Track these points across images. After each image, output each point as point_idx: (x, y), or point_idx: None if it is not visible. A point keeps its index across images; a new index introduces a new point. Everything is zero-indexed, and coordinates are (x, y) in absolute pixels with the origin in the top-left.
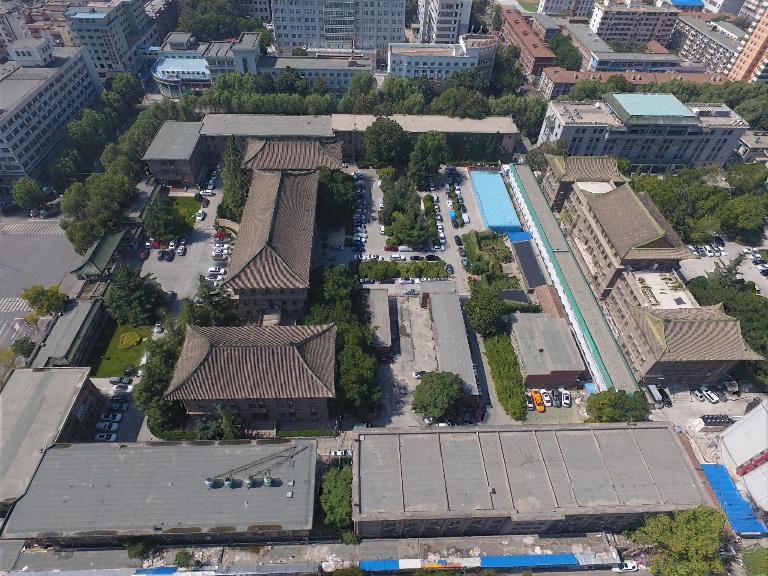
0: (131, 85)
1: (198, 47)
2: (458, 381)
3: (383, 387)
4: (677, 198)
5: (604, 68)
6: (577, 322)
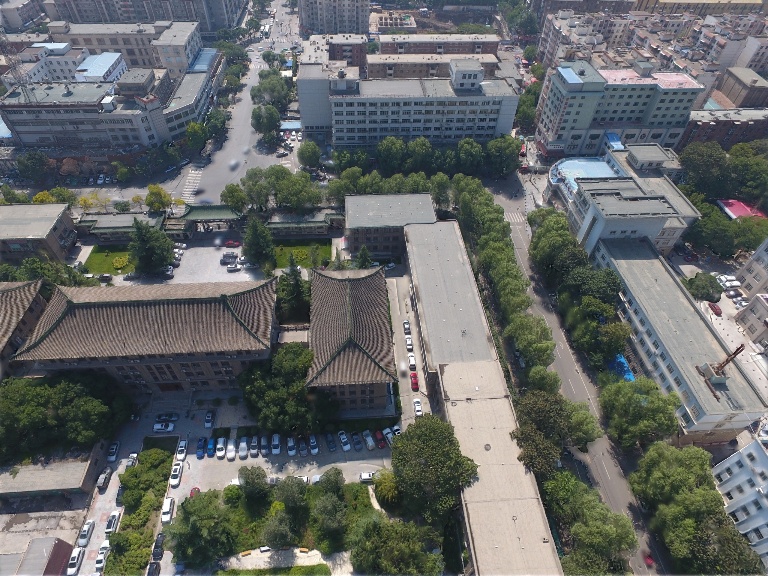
0: (505, 152)
1: (653, 177)
2: None
3: None
4: None
5: None
6: None
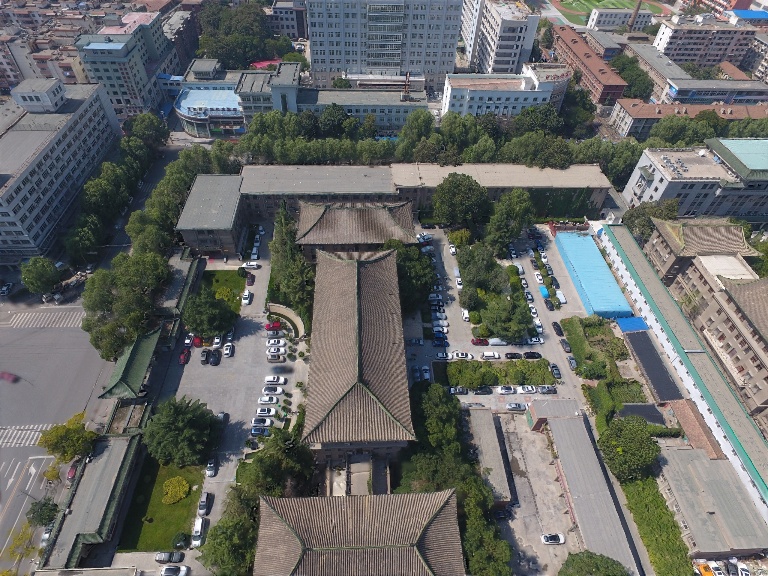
0: (154, 127)
1: (225, 76)
2: None
3: None
4: None
5: (683, 98)
6: (739, 461)
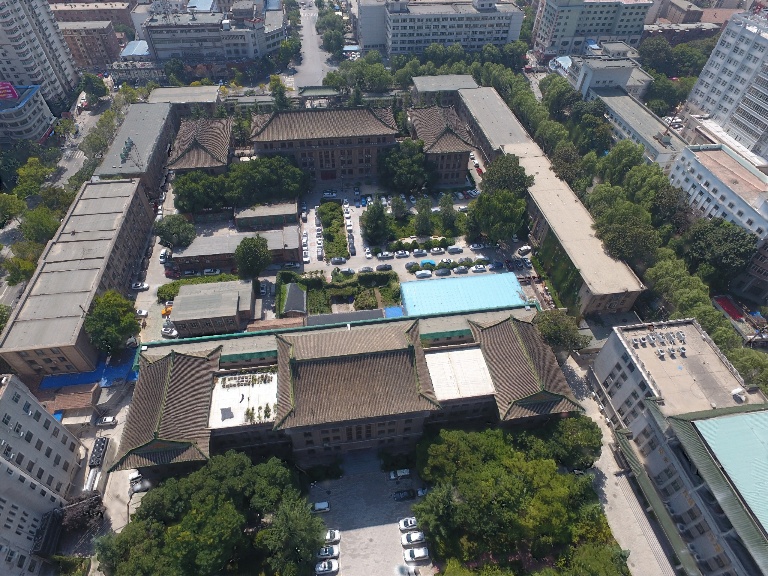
0: (517, 52)
1: None
2: (170, 230)
3: (208, 225)
4: (478, 496)
5: None
6: None
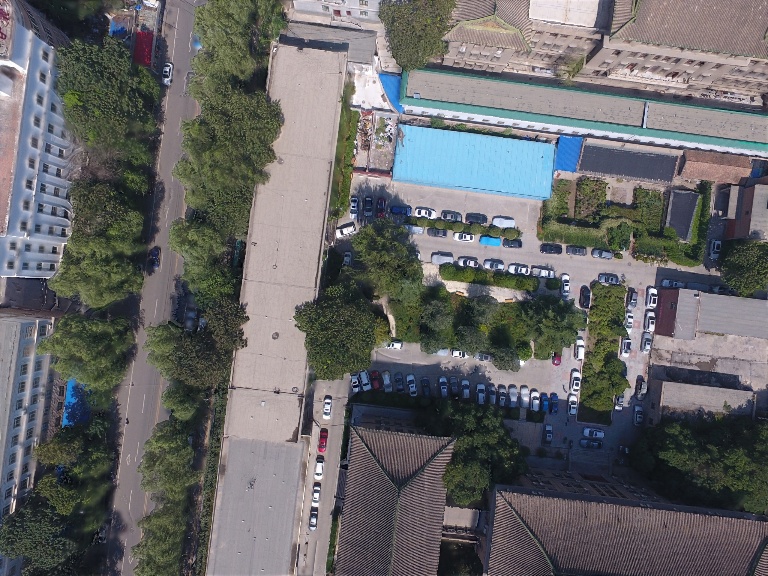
0: None
1: None
2: None
3: None
4: None
5: None
6: (765, 152)
